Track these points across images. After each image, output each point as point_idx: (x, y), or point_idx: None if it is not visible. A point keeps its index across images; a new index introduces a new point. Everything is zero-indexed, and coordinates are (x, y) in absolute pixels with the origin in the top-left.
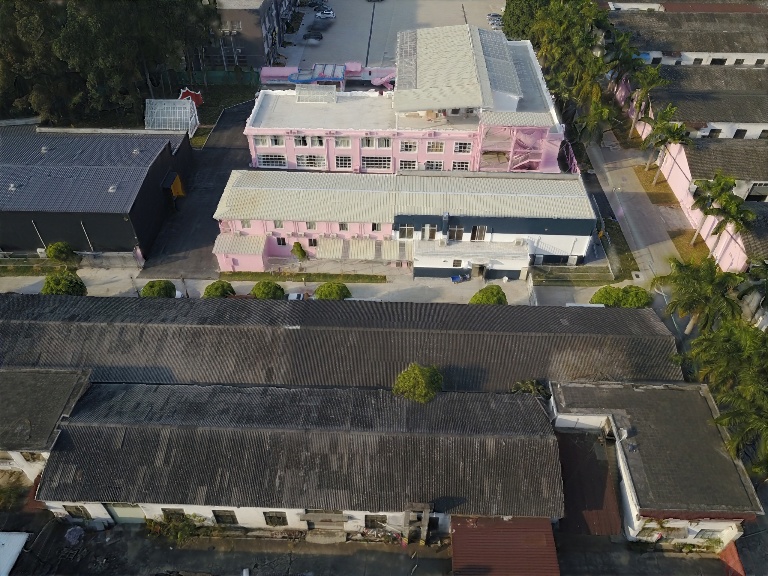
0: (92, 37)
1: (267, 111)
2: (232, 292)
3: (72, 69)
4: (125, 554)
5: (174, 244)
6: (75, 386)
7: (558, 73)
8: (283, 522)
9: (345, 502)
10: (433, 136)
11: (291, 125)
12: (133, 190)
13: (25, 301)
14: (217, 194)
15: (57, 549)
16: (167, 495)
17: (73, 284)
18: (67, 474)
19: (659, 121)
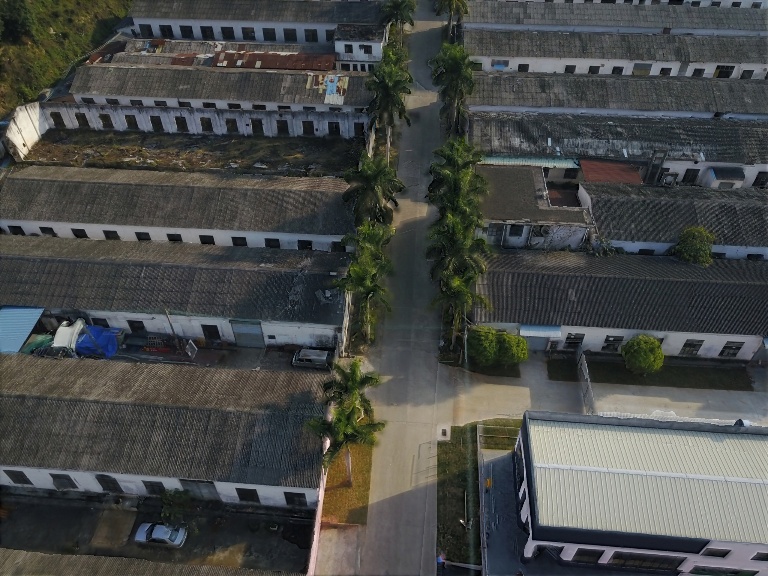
0: None
1: None
2: None
3: None
4: None
5: None
6: None
7: None
8: None
9: None
10: None
11: None
12: None
13: None
14: None
15: None
16: None
17: None
18: None
19: None
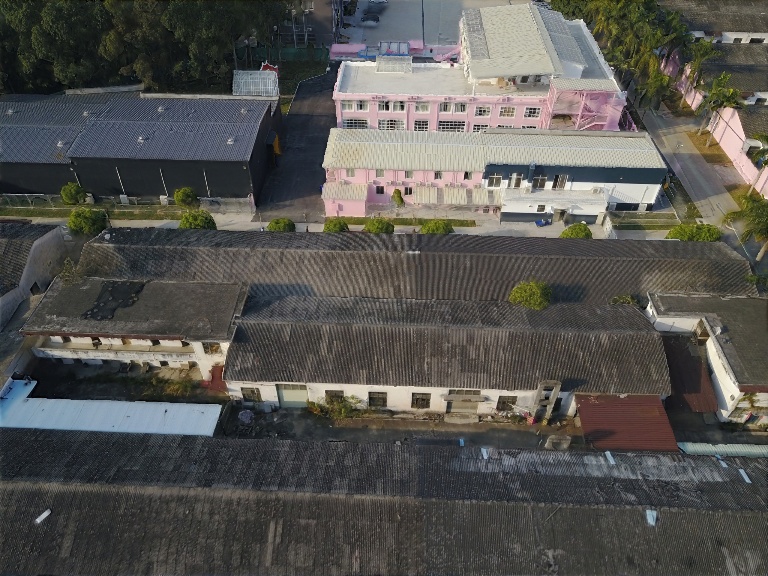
0: (197, 9)
1: (350, 80)
2: (347, 229)
3: (178, 39)
4: (293, 430)
5: (279, 194)
6: (239, 294)
7: (615, 47)
8: (426, 404)
9: (485, 383)
10: (506, 101)
11: (375, 91)
12: (249, 142)
13: (170, 233)
14: (309, 153)
15: (234, 426)
16: (333, 377)
17: (208, 220)
18: (246, 360)
19: (714, 87)
